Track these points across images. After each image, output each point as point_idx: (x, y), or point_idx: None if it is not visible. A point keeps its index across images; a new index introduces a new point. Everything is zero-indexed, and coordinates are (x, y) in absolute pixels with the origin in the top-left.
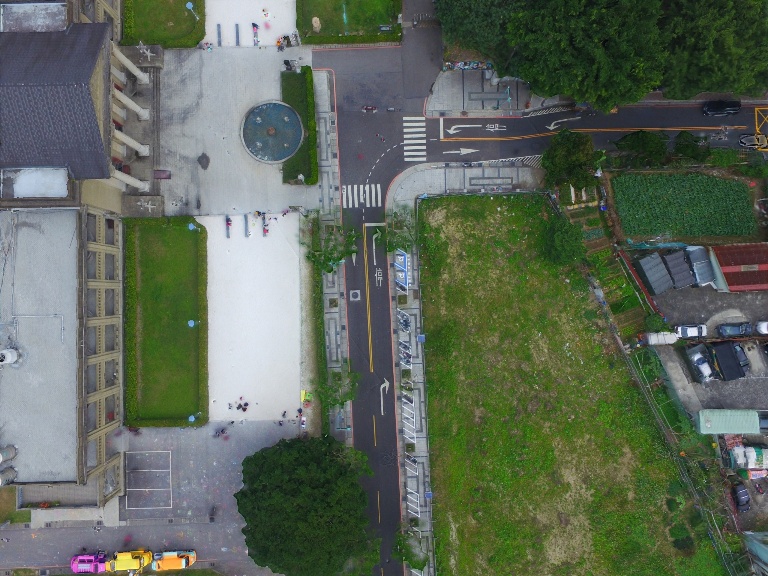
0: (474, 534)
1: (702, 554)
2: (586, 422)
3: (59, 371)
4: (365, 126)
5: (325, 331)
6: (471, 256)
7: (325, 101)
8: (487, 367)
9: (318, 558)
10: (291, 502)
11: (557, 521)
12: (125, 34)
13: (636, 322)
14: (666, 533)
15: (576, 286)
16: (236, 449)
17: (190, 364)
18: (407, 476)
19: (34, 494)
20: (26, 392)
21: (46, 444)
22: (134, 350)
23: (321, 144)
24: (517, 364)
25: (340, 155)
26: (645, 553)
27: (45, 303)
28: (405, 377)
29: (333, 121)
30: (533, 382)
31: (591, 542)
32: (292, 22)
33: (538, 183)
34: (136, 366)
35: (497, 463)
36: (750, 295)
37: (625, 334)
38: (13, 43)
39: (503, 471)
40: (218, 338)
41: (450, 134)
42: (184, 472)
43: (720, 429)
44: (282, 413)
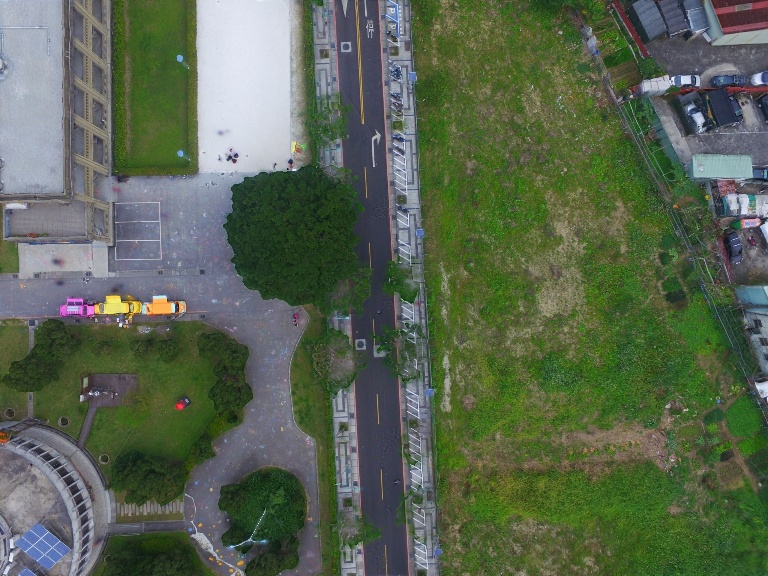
0: (466, 285)
1: (694, 308)
2: (579, 176)
3: (45, 84)
4: None
5: (316, 82)
6: (463, 7)
7: None
8: (479, 119)
9: (308, 273)
10: (280, 217)
11: (549, 273)
12: None
13: (629, 76)
14: (659, 287)
15: (569, 37)
16: (226, 200)
17: (179, 115)
18: (398, 228)
19: (21, 227)
20: (12, 105)
21: (32, 157)
22: (122, 98)
23: None
24: (509, 116)
25: None
26: (637, 305)
27: (30, 15)
28: (396, 128)
29: None
30: (525, 135)
31: (583, 294)
32: None
33: None
34: (125, 115)
35: (489, 214)
36: (744, 49)
37: (618, 88)
38: None
39: (495, 222)
40: (208, 90)
41: None
42: (174, 223)
43: (713, 173)
44: (272, 165)
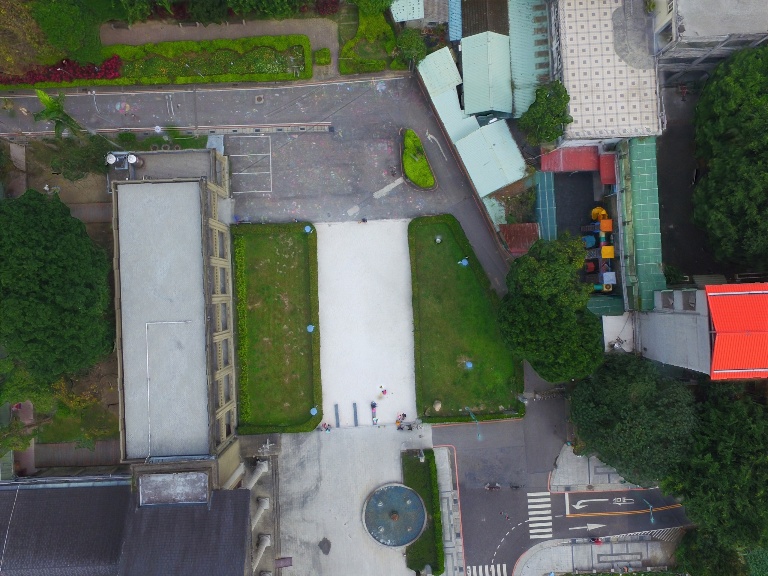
0: None
1: None
2: None
3: None
4: (488, 504)
5: None
6: None
7: (447, 480)
8: None
9: None
10: None
11: None
12: (241, 419)
13: None
14: None
15: None
16: None
17: None
18: None
19: None
20: None
21: None
22: None
23: (444, 525)
24: None
25: (464, 535)
26: None
27: None
28: None
29: (455, 499)
30: None
31: None
32: (410, 398)
33: (668, 557)
34: None
35: None
36: None
37: None
38: (157, 527)
39: None
40: None
41: (576, 509)
42: None
43: None
44: None
